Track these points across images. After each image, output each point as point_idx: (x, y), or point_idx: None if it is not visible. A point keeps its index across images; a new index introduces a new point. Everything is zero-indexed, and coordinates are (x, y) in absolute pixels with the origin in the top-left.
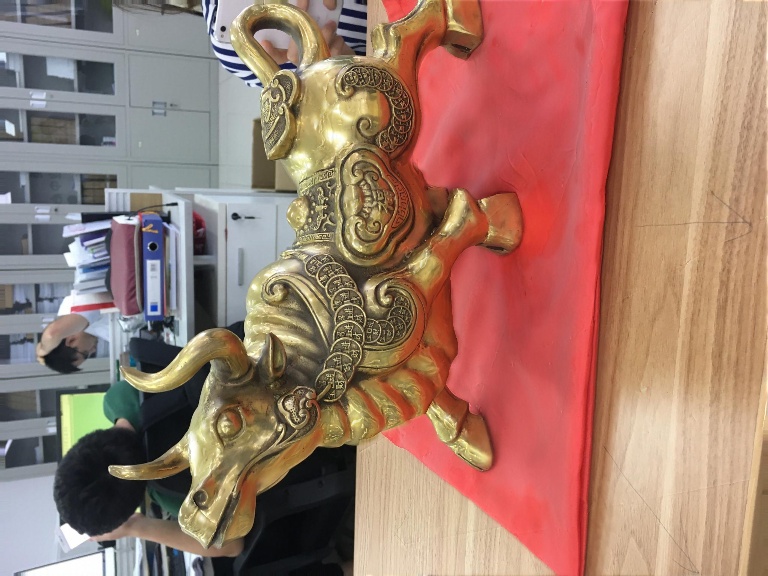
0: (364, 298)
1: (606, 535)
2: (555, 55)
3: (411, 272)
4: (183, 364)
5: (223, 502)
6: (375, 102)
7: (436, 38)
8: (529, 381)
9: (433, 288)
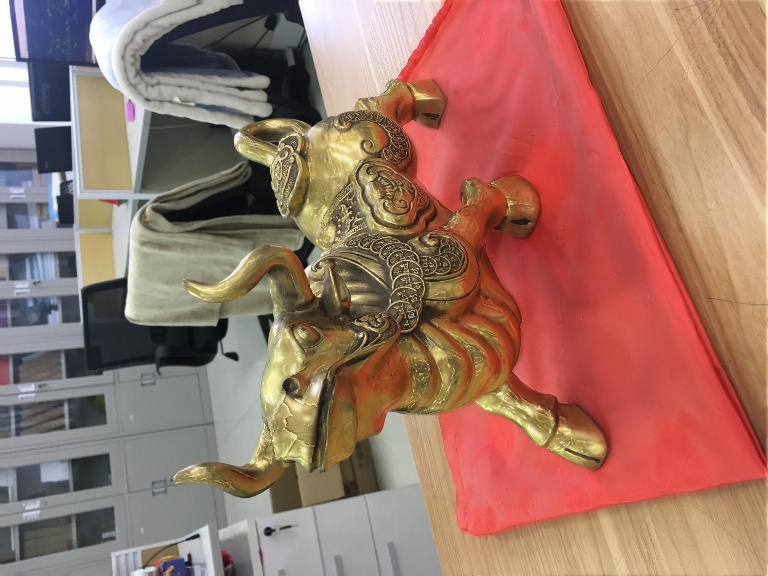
0: (410, 245)
1: (761, 385)
2: (508, 54)
3: (448, 228)
4: (247, 265)
5: (318, 386)
6: (372, 132)
7: (408, 107)
8: (604, 312)
9: (474, 238)
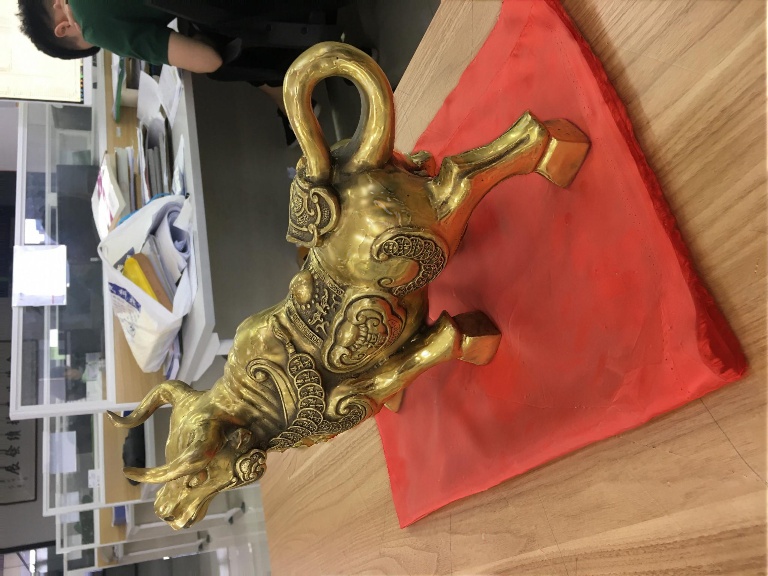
0: (327, 406)
1: (428, 533)
2: (589, 325)
3: (375, 388)
4: (169, 479)
5: (185, 520)
6: (407, 262)
7: None
8: (436, 430)
9: (388, 396)
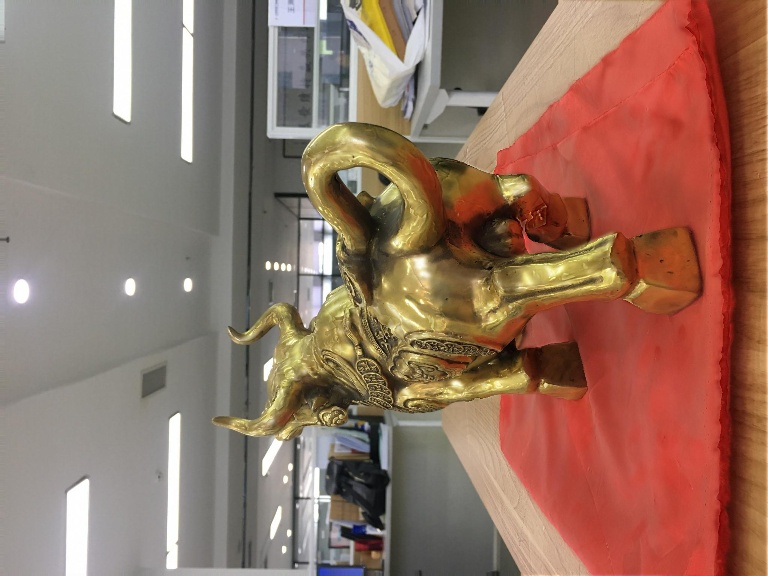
0: (395, 401)
1: None
2: (645, 478)
3: (444, 396)
4: None
5: (281, 438)
6: None
7: None
8: (532, 406)
9: None
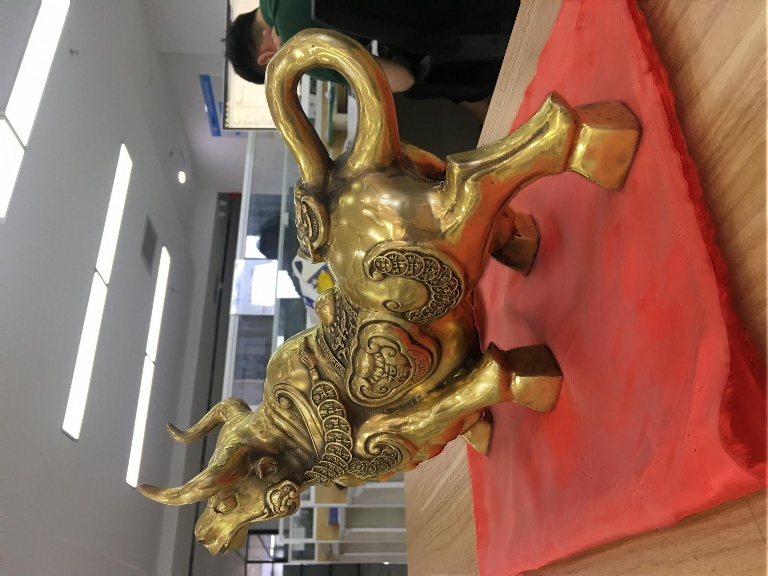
0: (354, 443)
1: None
2: (636, 374)
3: (409, 427)
4: (181, 502)
5: (218, 546)
6: (412, 282)
7: None
8: (510, 483)
9: (428, 439)
